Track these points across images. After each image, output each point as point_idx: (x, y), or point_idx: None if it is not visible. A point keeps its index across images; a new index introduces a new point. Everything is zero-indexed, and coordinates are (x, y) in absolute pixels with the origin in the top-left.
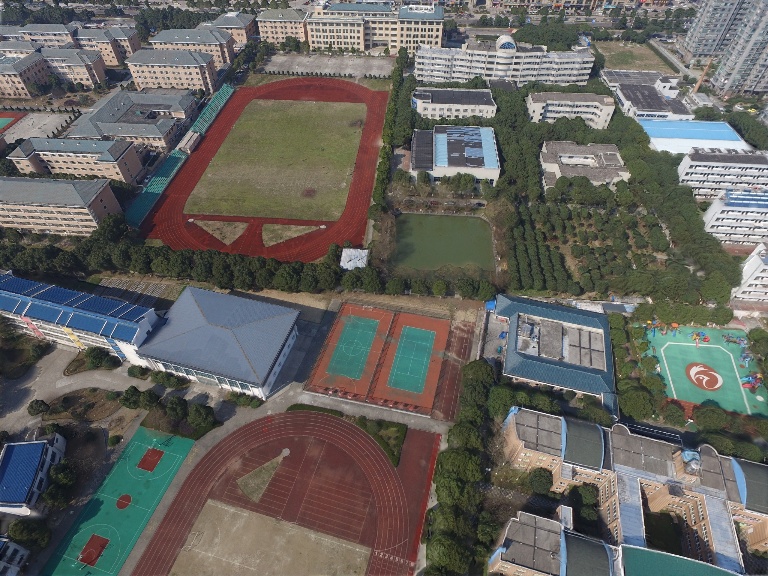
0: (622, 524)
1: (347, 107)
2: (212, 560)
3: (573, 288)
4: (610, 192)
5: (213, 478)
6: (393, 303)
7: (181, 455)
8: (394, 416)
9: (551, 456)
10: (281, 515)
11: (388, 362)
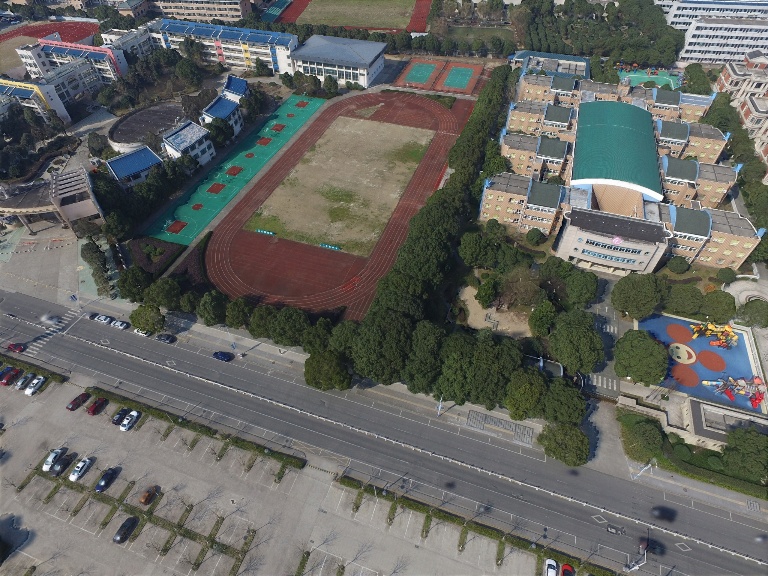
0: None
1: None
2: (346, 131)
3: (568, 48)
4: (601, 6)
5: (340, 110)
6: (445, 59)
7: (320, 103)
8: (448, 95)
9: (544, 87)
10: (383, 121)
11: (443, 78)
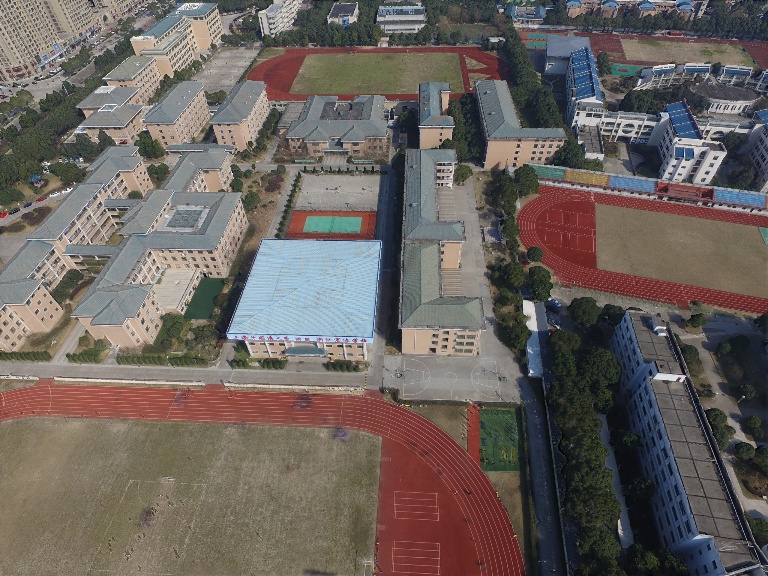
0: (595, 1)
1: (313, 59)
2: None
3: None
4: None
5: (620, 60)
6: None
7: None
8: None
9: None
10: None
11: None
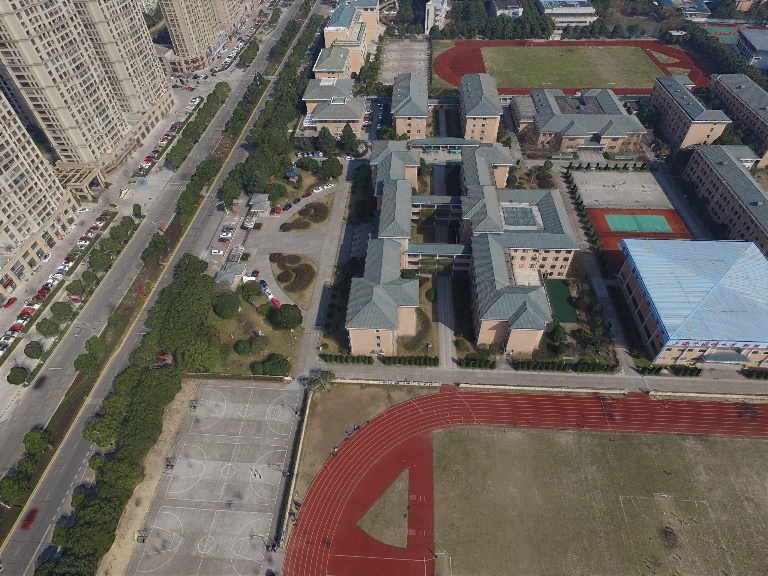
0: None
1: (490, 52)
2: None
3: None
4: None
5: None
6: None
7: None
8: None
9: None
10: None
11: None
